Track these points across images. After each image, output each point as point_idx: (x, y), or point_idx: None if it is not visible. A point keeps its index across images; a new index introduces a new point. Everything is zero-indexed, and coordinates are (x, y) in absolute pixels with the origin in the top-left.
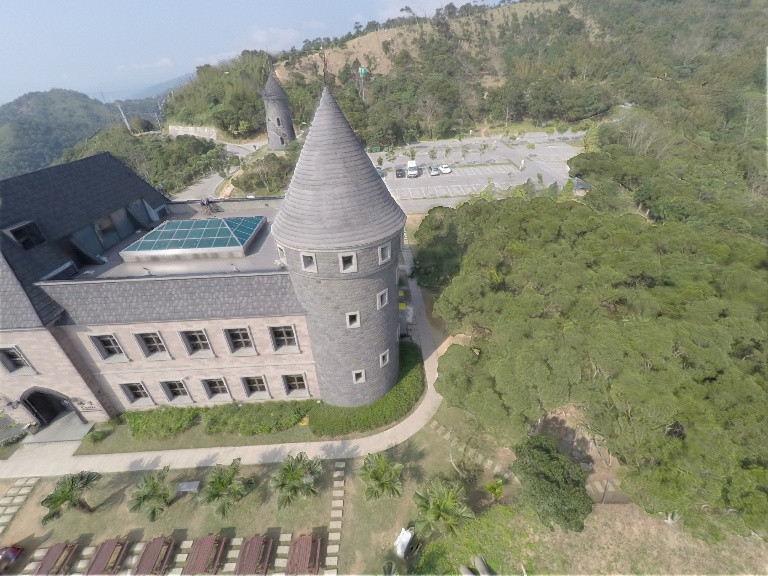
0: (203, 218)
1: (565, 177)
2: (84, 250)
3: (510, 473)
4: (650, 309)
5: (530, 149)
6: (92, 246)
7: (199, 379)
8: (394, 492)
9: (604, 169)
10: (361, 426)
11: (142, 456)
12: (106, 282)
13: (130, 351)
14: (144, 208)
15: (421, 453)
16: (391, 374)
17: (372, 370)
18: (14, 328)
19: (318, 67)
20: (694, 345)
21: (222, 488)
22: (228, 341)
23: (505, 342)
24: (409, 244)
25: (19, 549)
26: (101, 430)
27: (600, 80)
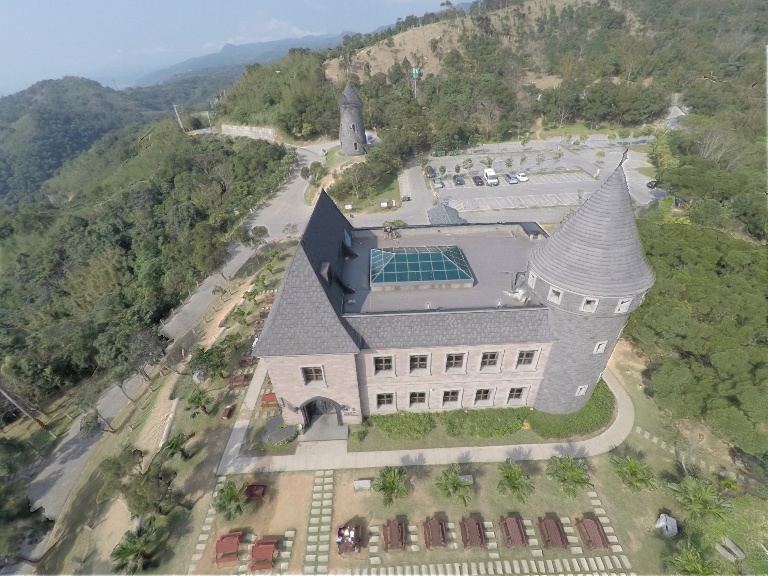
0: None
1: (643, 187)
2: (342, 282)
3: (724, 472)
4: None
5: (600, 157)
6: None
7: (443, 390)
8: (652, 486)
9: (696, 185)
10: (581, 431)
11: (407, 453)
12: (400, 315)
13: (399, 369)
14: (343, 236)
15: (640, 454)
16: None
17: (592, 385)
18: (336, 353)
19: (370, 67)
20: None
21: None
22: None
23: (729, 367)
24: None
25: (360, 526)
26: (357, 431)
27: None
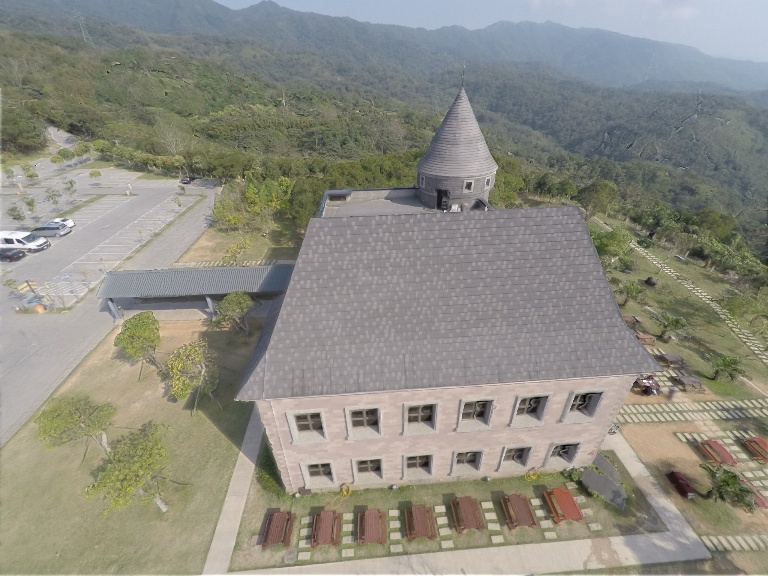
0: None
1: None
2: None
3: None
4: None
5: (97, 177)
6: None
7: None
8: None
9: None
10: None
11: None
12: None
13: None
14: None
15: None
16: None
17: None
18: None
19: None
20: None
21: None
22: None
23: None
24: (261, 260)
25: None
26: None
27: None
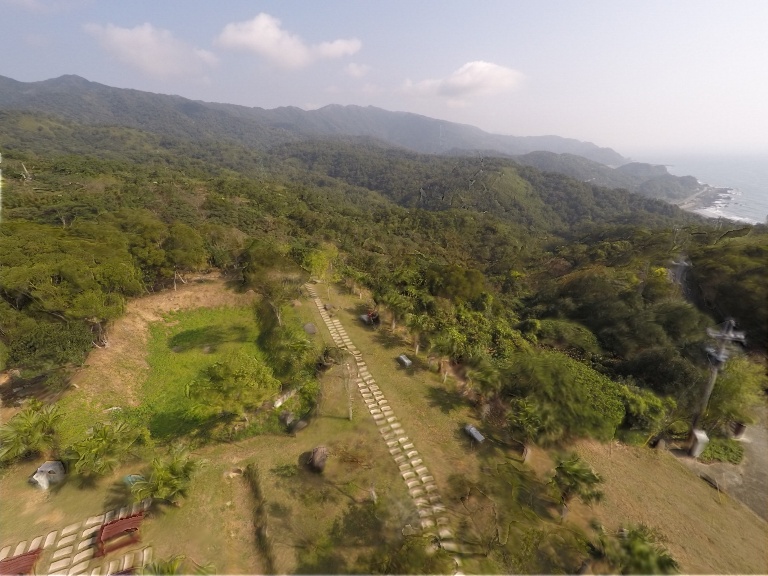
0: None
1: None
2: None
3: None
4: None
5: None
6: None
7: None
8: None
9: None
10: None
11: None
12: None
13: None
14: None
15: None
16: None
17: None
18: None
19: None
20: (3, 256)
21: None
22: None
23: None
24: None
25: None
26: None
27: None
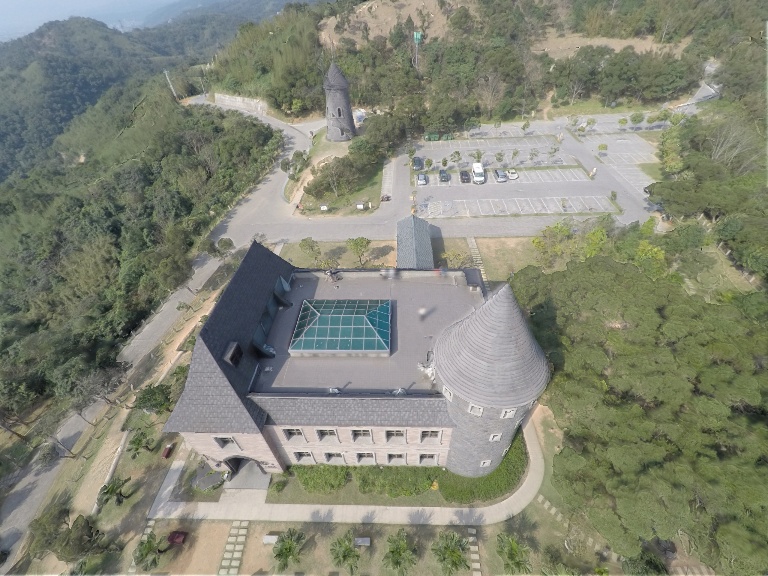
0: (330, 292)
1: (639, 191)
2: (261, 348)
3: (608, 552)
4: (751, 452)
5: (602, 150)
6: (260, 338)
7: (355, 453)
8: (526, 570)
9: (688, 201)
10: (483, 497)
11: (318, 509)
12: (302, 398)
13: (309, 437)
14: (280, 282)
15: (534, 526)
16: (505, 454)
17: (496, 459)
18: (239, 432)
19: (369, 29)
20: None
21: (398, 555)
22: (386, 436)
23: (620, 464)
24: (488, 280)
25: None
26: (278, 481)
27: (681, 38)
